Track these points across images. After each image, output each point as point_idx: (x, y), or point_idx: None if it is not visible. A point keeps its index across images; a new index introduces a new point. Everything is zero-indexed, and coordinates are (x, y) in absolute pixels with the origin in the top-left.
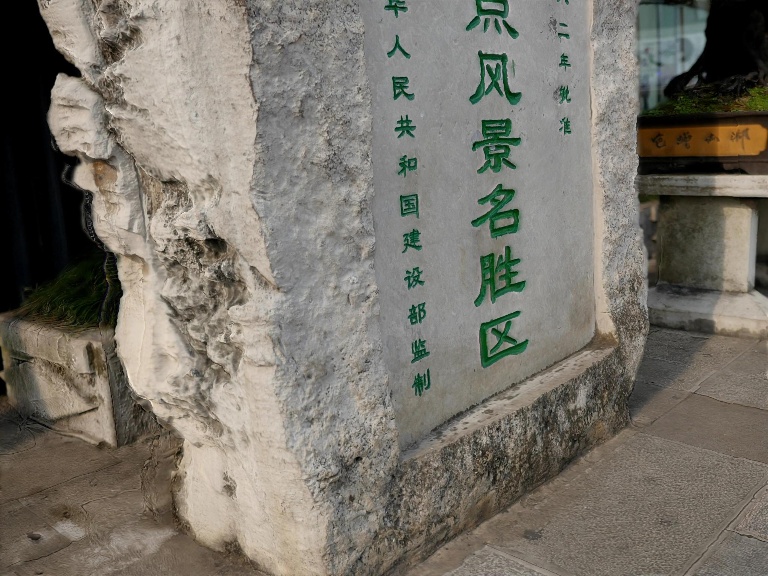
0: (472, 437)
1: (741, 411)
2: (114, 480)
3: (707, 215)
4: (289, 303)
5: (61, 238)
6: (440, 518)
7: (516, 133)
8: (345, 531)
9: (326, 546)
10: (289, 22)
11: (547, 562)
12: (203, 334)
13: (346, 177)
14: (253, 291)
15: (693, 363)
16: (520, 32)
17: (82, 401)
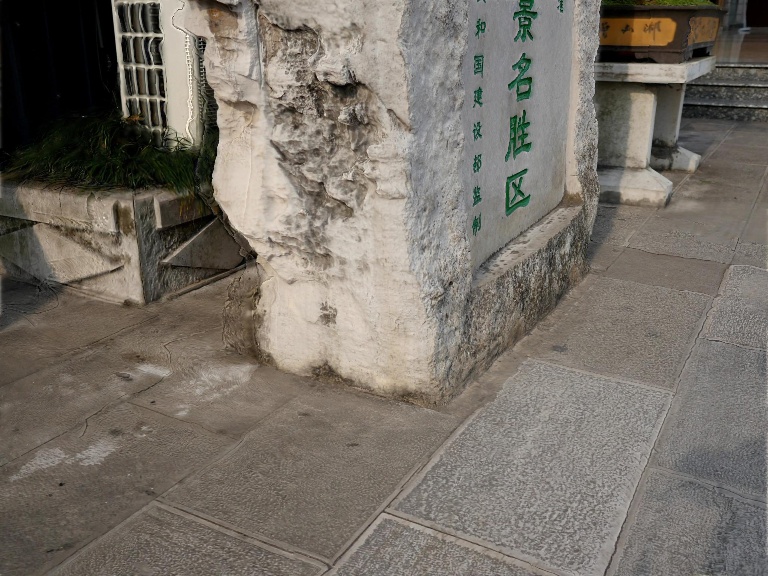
0: (513, 271)
1: (669, 259)
2: (173, 327)
3: (616, 99)
4: (416, 144)
5: (17, 103)
6: (494, 337)
7: (535, 7)
8: (444, 343)
9: (433, 354)
10: None
11: (582, 365)
12: (320, 175)
13: (452, 33)
14: (389, 132)
15: (614, 226)
16: None
17: (113, 259)
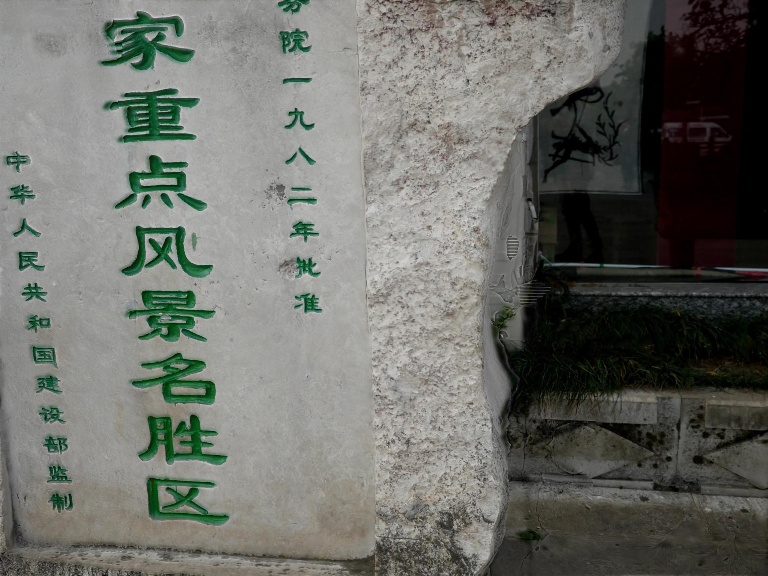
0: (73, 568)
1: None
2: None
3: None
4: None
5: None
6: None
7: (206, 306)
8: None
9: None
10: None
11: None
12: None
13: None
14: None
15: None
16: (210, 203)
17: None
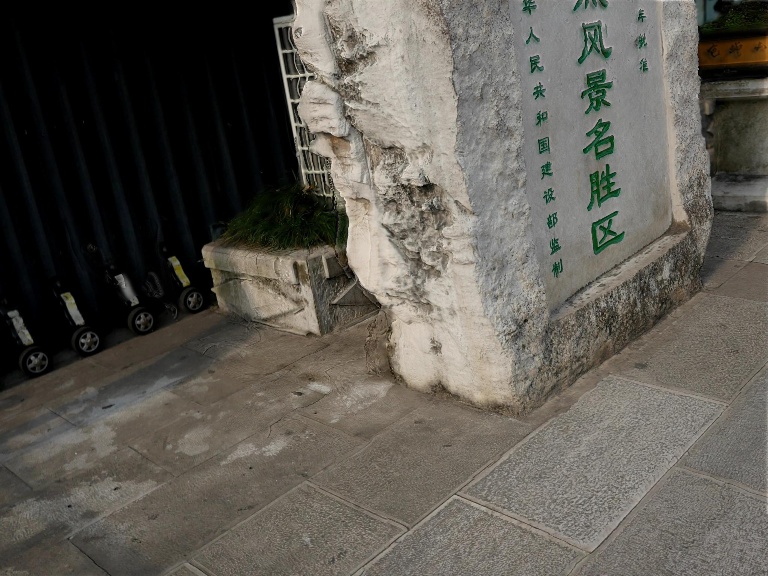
0: (594, 303)
1: None
2: (335, 356)
3: (758, 112)
4: (480, 222)
5: (232, 183)
6: (577, 359)
7: (610, 78)
8: (522, 367)
9: (511, 377)
10: (472, 38)
11: (654, 381)
12: (417, 247)
13: (508, 134)
14: (457, 216)
15: (750, 238)
16: (609, 1)
17: (295, 304)
